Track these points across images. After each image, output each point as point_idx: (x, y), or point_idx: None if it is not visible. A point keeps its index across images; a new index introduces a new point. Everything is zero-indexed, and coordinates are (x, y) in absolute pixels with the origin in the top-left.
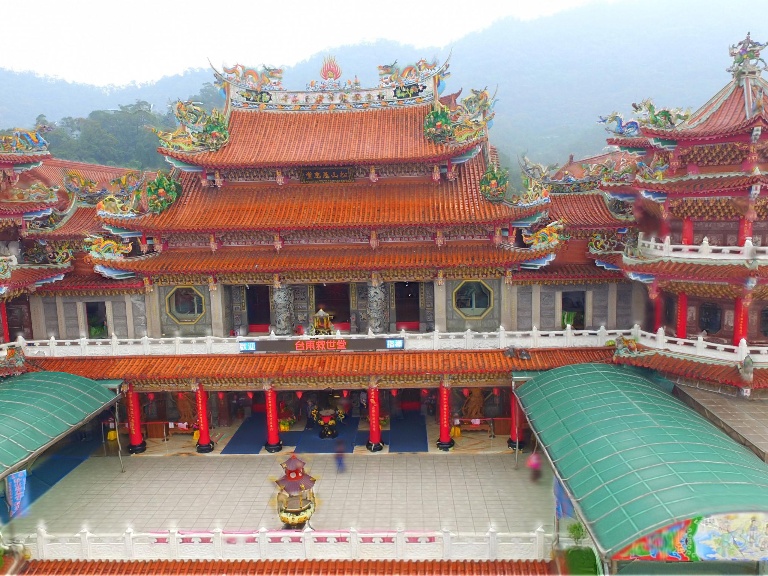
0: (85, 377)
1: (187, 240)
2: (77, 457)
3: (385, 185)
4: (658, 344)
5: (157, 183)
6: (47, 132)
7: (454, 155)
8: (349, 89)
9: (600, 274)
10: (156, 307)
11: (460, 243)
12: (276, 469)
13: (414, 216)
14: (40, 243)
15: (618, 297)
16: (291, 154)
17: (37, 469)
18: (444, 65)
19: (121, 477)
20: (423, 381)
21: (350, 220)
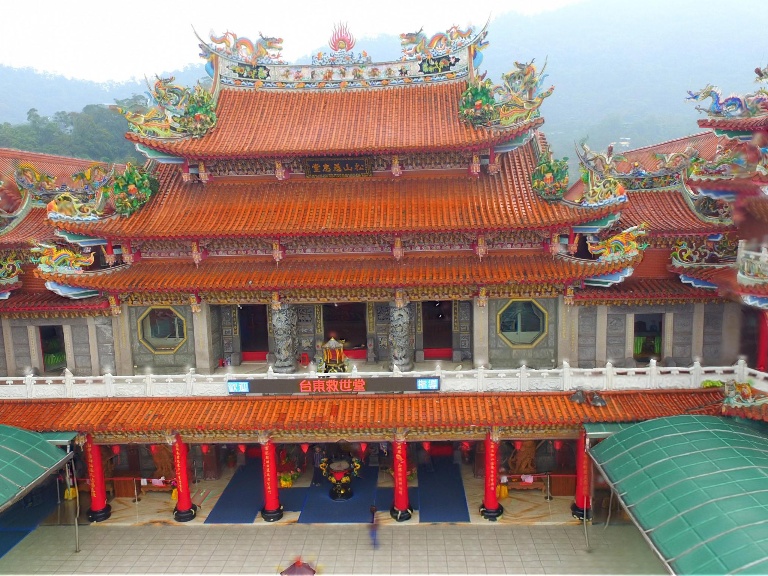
0: (27, 429)
1: (164, 249)
2: (20, 529)
3: (410, 180)
4: None
5: (126, 178)
6: (39, 127)
7: (499, 142)
8: (364, 62)
9: (688, 293)
10: (125, 332)
11: (506, 253)
12: (275, 548)
13: (449, 219)
14: None
15: (705, 321)
16: (294, 141)
17: None
18: (481, 32)
19: (73, 560)
20: (464, 432)
21: (368, 224)
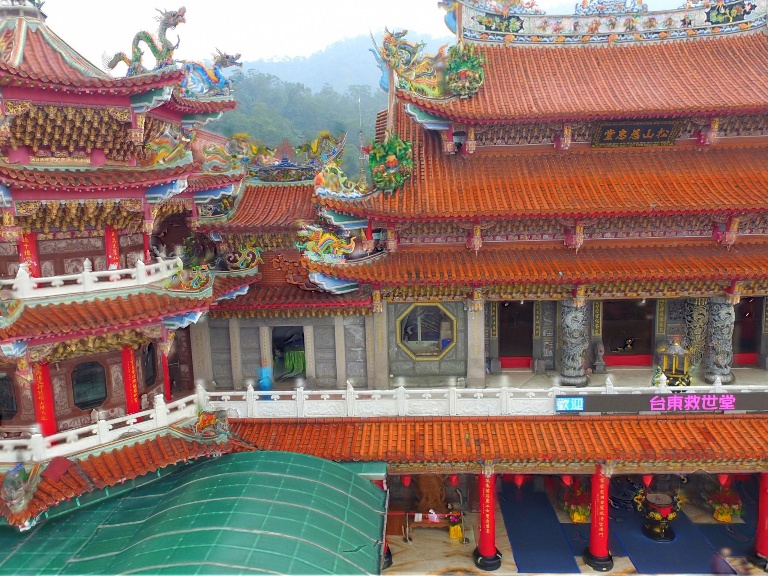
0: (322, 458)
1: (431, 233)
2: None
3: (721, 149)
4: None
5: (386, 146)
6: None
7: None
8: (639, 11)
9: None
10: (383, 335)
11: None
12: None
13: None
14: (211, 238)
15: None
16: (589, 101)
17: None
18: None
19: None
20: None
21: (707, 201)
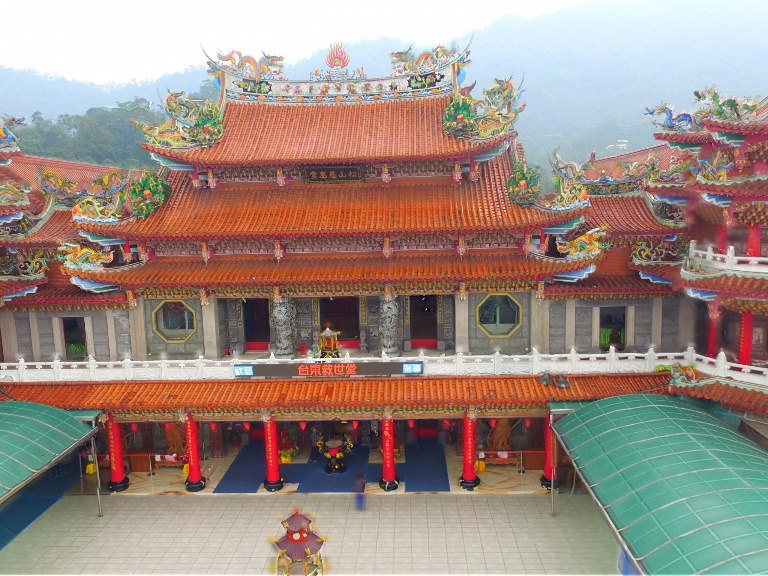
0: (57, 407)
1: (176, 248)
2: (49, 497)
3: (399, 186)
4: (718, 371)
5: (142, 184)
6: (43, 130)
7: (478, 152)
8: (358, 78)
9: (645, 288)
10: (141, 323)
11: (484, 252)
12: (276, 513)
13: (433, 221)
14: (10, 251)
15: (664, 313)
16: (293, 151)
17: (1, 513)
18: (464, 51)
19: (98, 523)
20: (445, 411)
21: (360, 226)
